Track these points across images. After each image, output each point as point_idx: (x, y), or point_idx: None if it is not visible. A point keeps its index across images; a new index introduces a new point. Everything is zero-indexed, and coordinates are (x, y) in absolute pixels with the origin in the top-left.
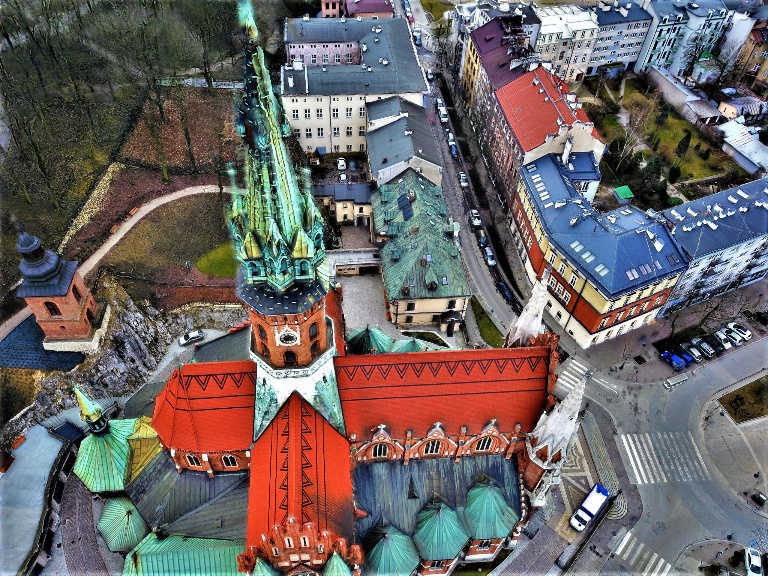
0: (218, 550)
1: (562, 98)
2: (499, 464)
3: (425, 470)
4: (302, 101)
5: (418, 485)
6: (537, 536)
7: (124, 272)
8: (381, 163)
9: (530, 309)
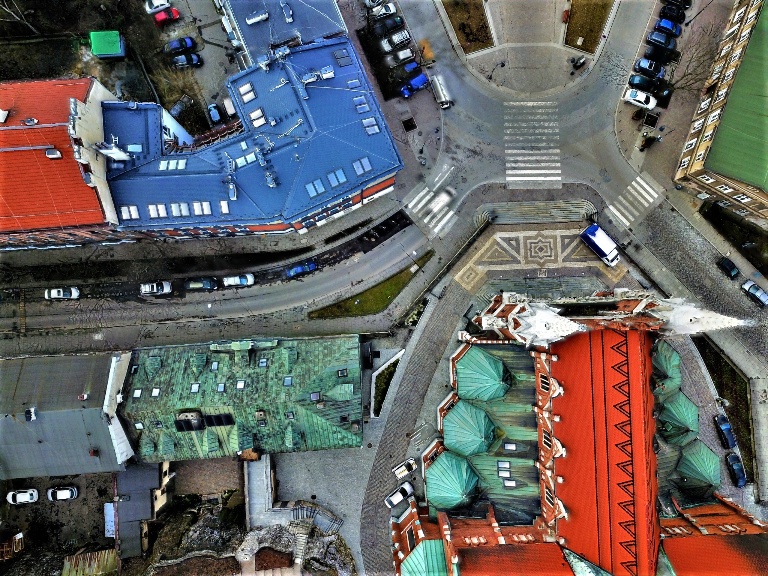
0: None
1: None
2: None
3: None
4: None
5: None
6: None
7: None
8: (97, 458)
9: None
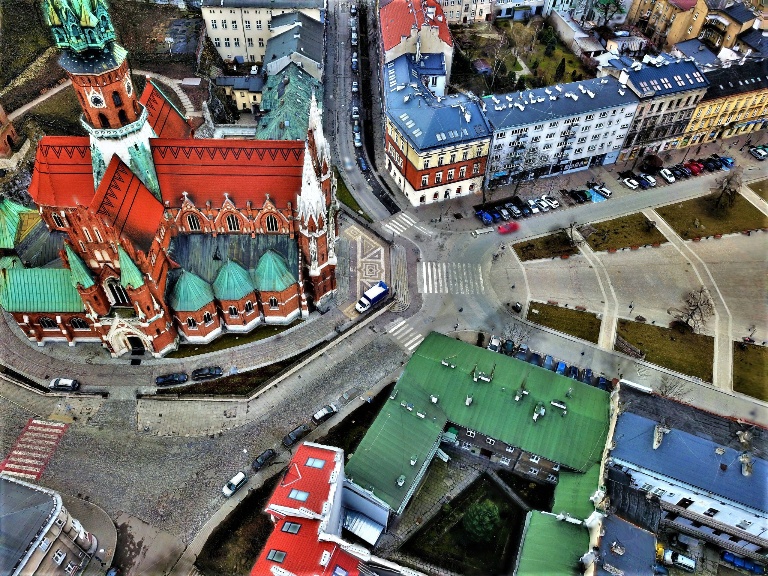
0: (63, 271)
1: (422, 9)
2: (285, 242)
3: (229, 242)
4: (218, 12)
5: (222, 252)
6: (327, 314)
7: (47, 121)
8: (271, 59)
9: (310, 124)
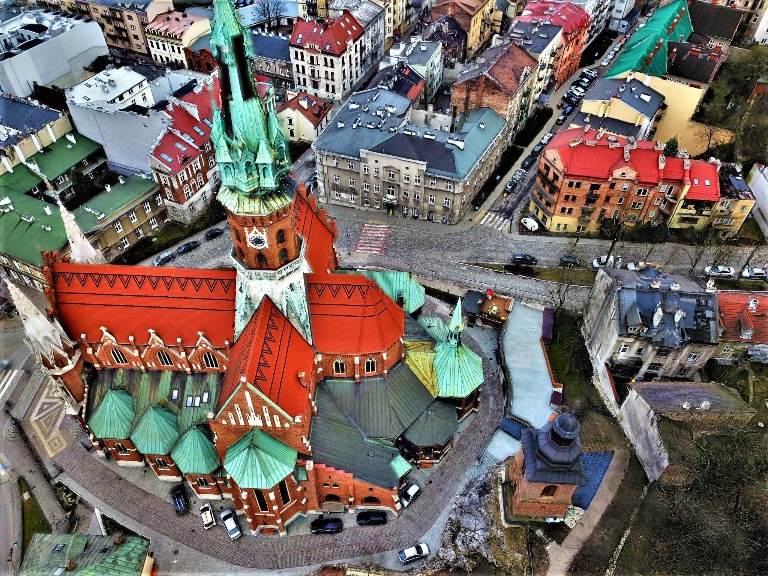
0: None
1: None
2: None
3: None
4: None
5: None
6: None
7: None
8: None
9: None
